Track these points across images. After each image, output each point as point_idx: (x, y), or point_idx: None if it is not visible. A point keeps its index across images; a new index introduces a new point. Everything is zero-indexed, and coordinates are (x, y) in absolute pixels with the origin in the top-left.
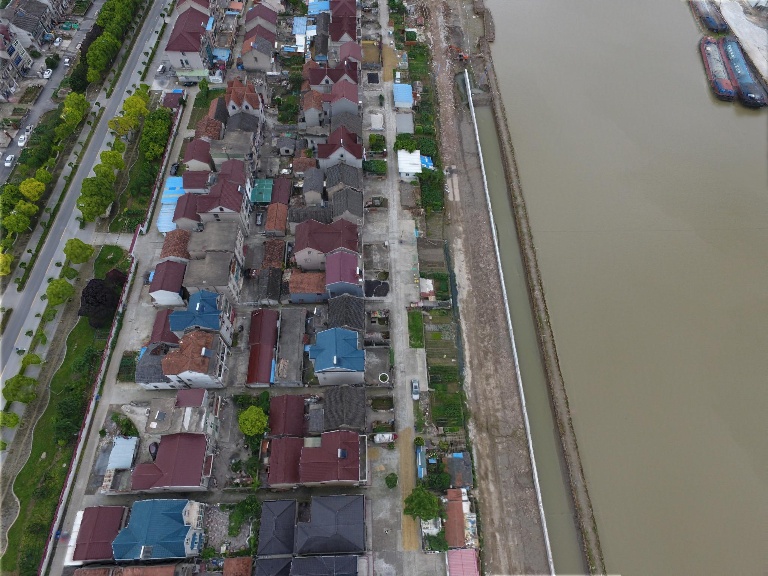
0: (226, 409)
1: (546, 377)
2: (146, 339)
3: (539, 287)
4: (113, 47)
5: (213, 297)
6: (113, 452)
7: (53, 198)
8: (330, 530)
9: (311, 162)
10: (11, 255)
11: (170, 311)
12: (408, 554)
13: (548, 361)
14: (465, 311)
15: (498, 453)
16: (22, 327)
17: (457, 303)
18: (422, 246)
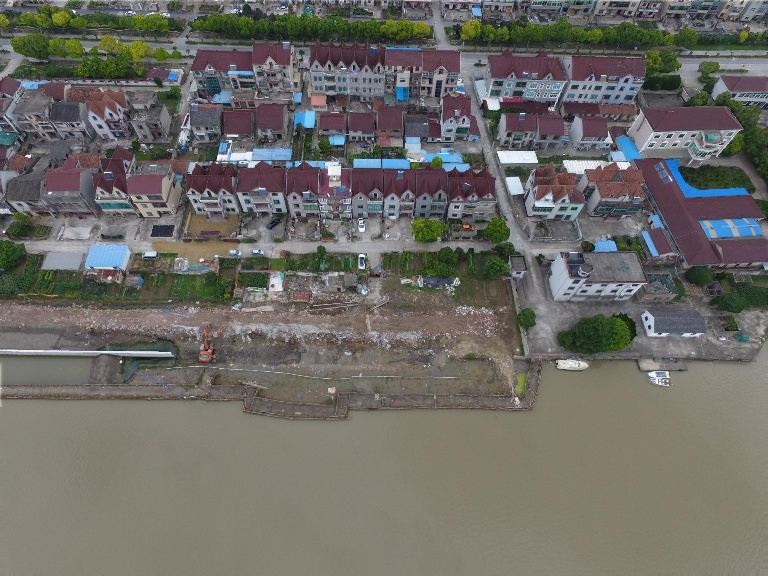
0: None
1: None
2: None
3: None
4: (236, 28)
5: None
6: None
7: (72, 36)
8: None
9: (8, 166)
10: (5, 24)
11: None
12: None
13: None
14: None
15: None
16: None
17: None
18: None
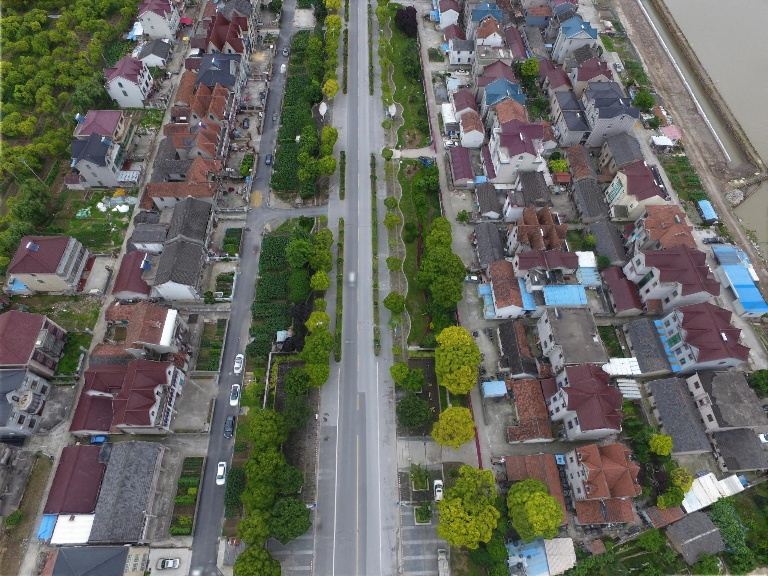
0: None
1: (693, 73)
2: (438, 44)
3: (679, 30)
4: None
5: (495, 3)
6: (449, 83)
7: None
8: (607, 89)
9: None
10: None
11: (455, 25)
12: (636, 130)
13: (694, 63)
14: (634, 40)
15: (674, 99)
16: (358, 37)
17: (628, 36)
18: (596, 9)
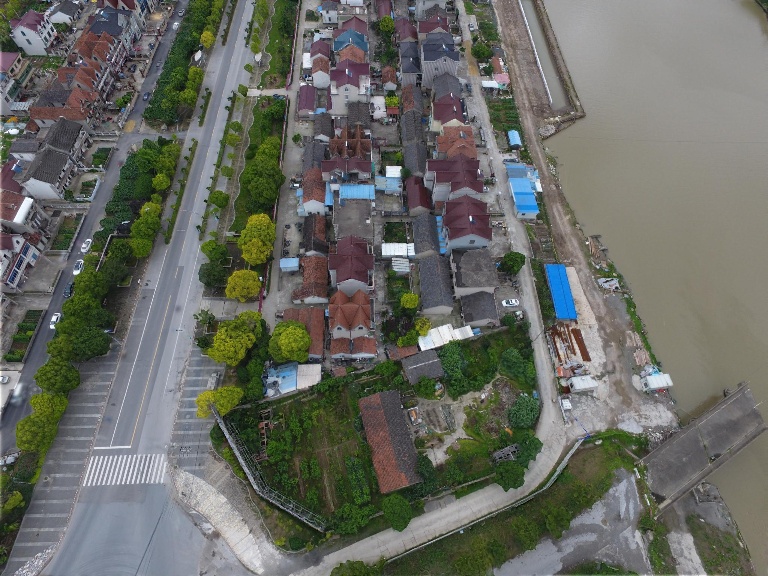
0: (368, 31)
1: (544, 34)
2: None
3: None
4: None
5: None
6: (315, 37)
7: None
8: (438, 38)
9: None
10: None
11: None
12: (473, 76)
13: (545, 25)
14: (496, 6)
15: (518, 54)
16: (247, 1)
17: (491, 3)
18: None
